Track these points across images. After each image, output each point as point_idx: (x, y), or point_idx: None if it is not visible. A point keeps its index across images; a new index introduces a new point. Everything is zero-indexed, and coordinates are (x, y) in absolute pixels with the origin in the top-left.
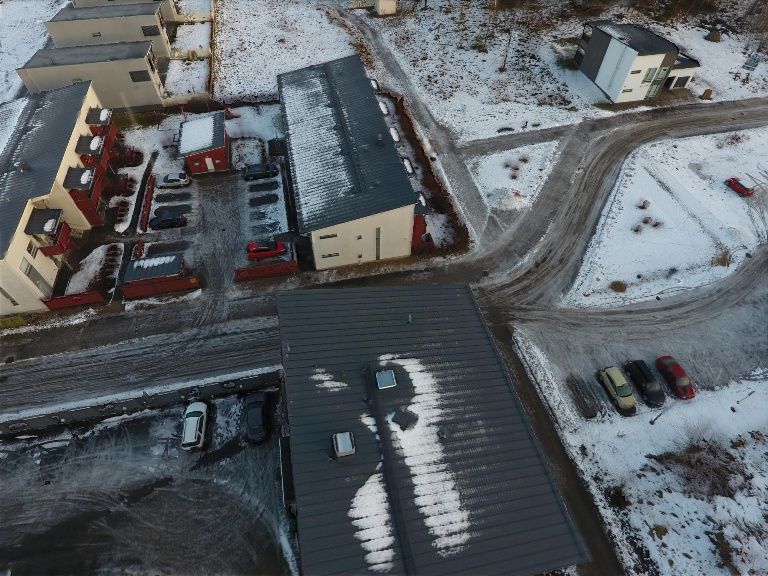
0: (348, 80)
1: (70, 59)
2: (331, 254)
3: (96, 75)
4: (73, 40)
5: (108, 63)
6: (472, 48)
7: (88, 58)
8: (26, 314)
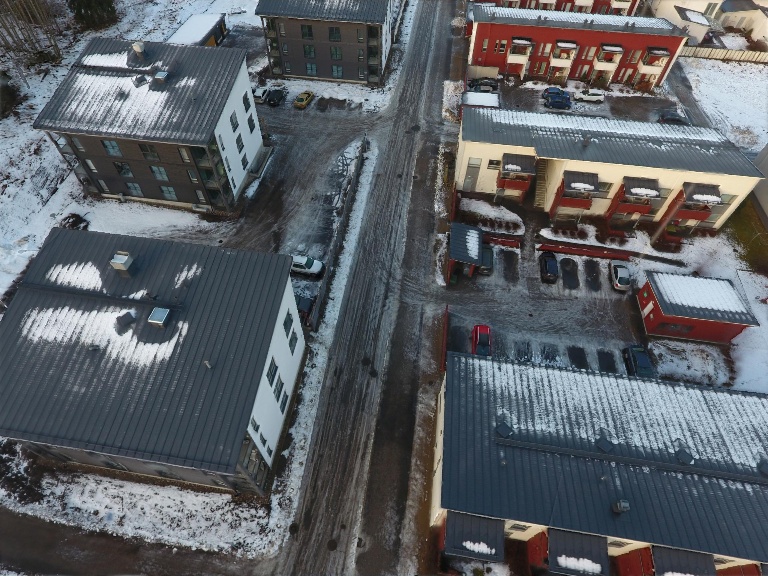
0: None
1: None
2: None
3: None
4: None
5: None
6: None
7: None
8: None
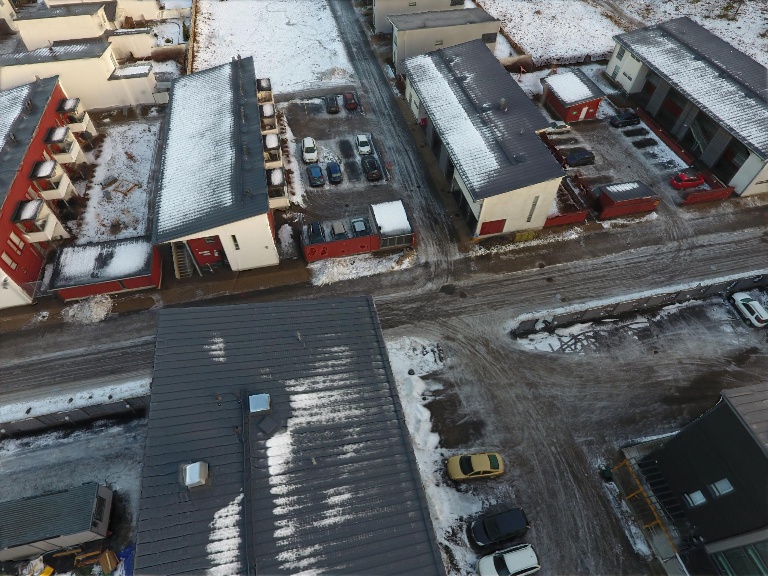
0: (697, 38)
1: (432, 23)
2: (763, 181)
3: (455, 37)
4: (392, 9)
5: (471, 25)
6: (718, 17)
7: (447, 22)
8: (526, 231)
